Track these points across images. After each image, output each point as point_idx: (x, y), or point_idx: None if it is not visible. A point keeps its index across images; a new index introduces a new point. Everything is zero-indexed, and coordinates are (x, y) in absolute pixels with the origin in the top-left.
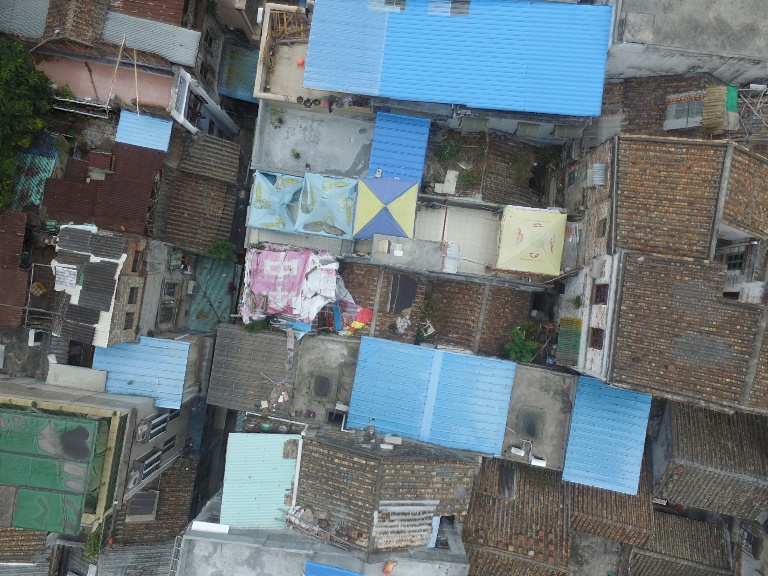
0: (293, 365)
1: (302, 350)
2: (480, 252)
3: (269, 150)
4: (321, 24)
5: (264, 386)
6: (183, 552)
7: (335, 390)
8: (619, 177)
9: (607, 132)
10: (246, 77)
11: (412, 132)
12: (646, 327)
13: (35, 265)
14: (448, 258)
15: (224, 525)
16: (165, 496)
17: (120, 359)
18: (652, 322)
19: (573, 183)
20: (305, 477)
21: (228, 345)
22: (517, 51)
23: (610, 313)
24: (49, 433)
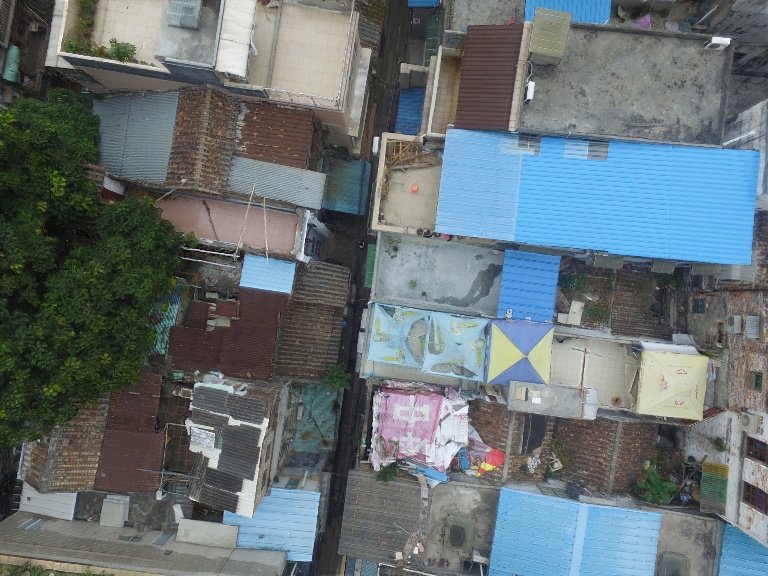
0: (428, 515)
1: (434, 496)
2: (607, 384)
3: (383, 277)
4: (452, 167)
5: (398, 536)
6: None
7: (471, 540)
8: None
9: (742, 265)
10: (345, 188)
11: (542, 270)
12: None
13: (169, 425)
14: (587, 404)
15: None
16: None
17: None
18: None
19: (702, 313)
20: None
21: (359, 494)
22: (660, 196)
23: None
24: None
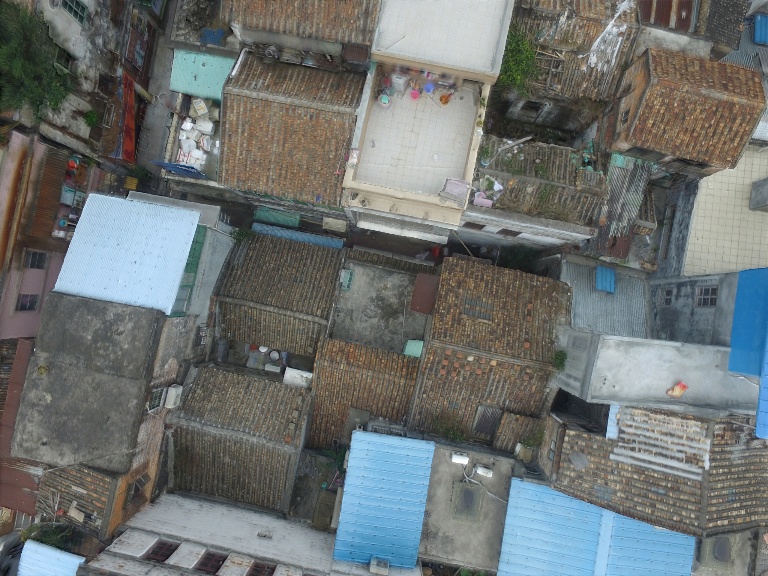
0: None
1: None
2: None
3: None
4: None
5: None
6: None
7: (706, 544)
8: None
9: None
10: None
11: None
12: None
13: None
14: None
15: None
16: None
17: None
18: None
19: None
20: None
21: None
22: None
23: None
24: None
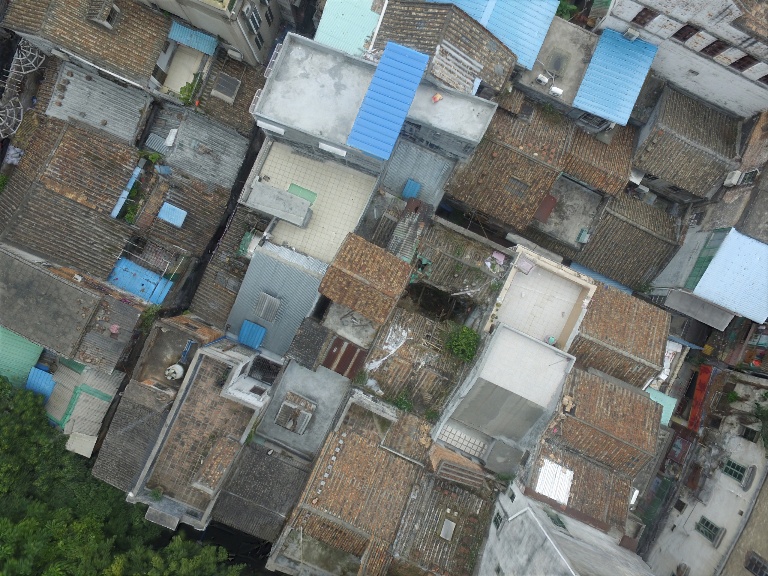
0: None
1: None
2: None
3: None
4: None
5: None
6: (285, 45)
7: None
8: None
9: None
10: None
11: None
12: None
13: None
14: None
15: None
16: (244, 90)
17: None
18: None
19: None
20: (384, 29)
21: None
22: None
23: None
24: None
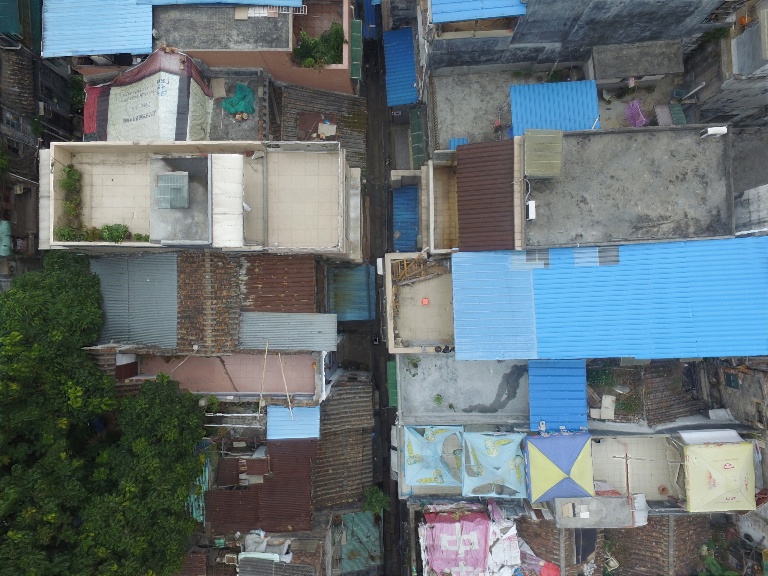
0: None
1: None
2: (651, 473)
3: (407, 395)
4: (463, 291)
5: None
6: None
7: None
8: None
9: None
10: (352, 297)
11: (569, 376)
12: None
13: None
14: (637, 511)
15: None
16: None
17: None
18: None
19: (736, 388)
20: None
21: None
22: (679, 294)
23: None
24: None
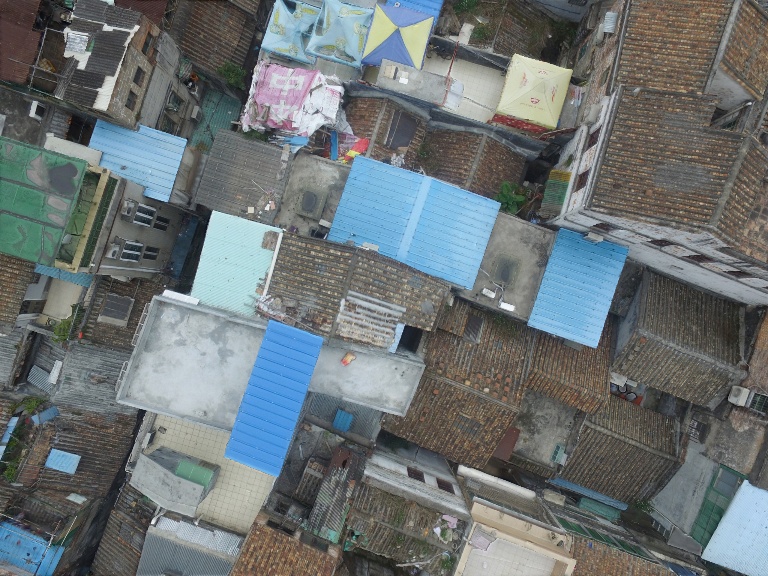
0: (284, 177)
1: (295, 167)
2: (483, 109)
3: None
4: None
5: (253, 193)
6: (151, 312)
7: (321, 207)
8: (629, 21)
9: None
10: None
11: None
12: (631, 155)
13: (48, 30)
14: (451, 94)
15: (194, 298)
16: (139, 307)
17: (117, 143)
18: (638, 151)
19: (584, 54)
20: (280, 269)
21: (224, 149)
22: None
23: (599, 147)
24: (39, 165)
